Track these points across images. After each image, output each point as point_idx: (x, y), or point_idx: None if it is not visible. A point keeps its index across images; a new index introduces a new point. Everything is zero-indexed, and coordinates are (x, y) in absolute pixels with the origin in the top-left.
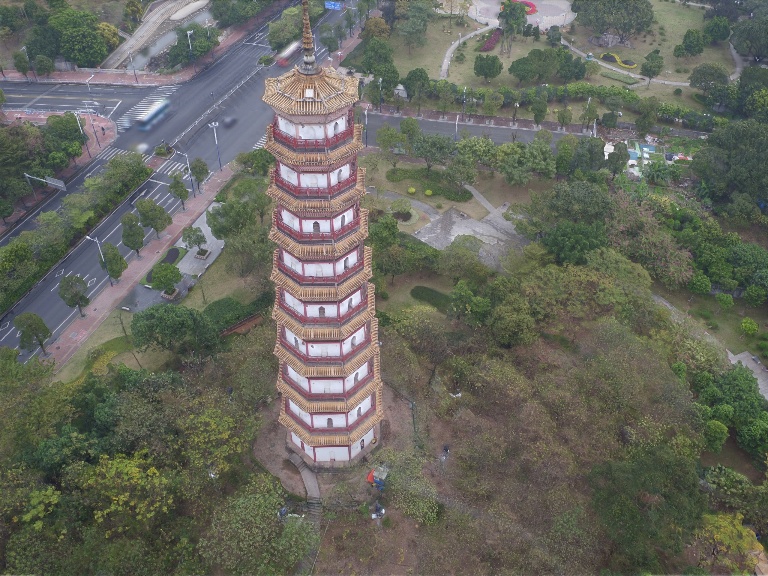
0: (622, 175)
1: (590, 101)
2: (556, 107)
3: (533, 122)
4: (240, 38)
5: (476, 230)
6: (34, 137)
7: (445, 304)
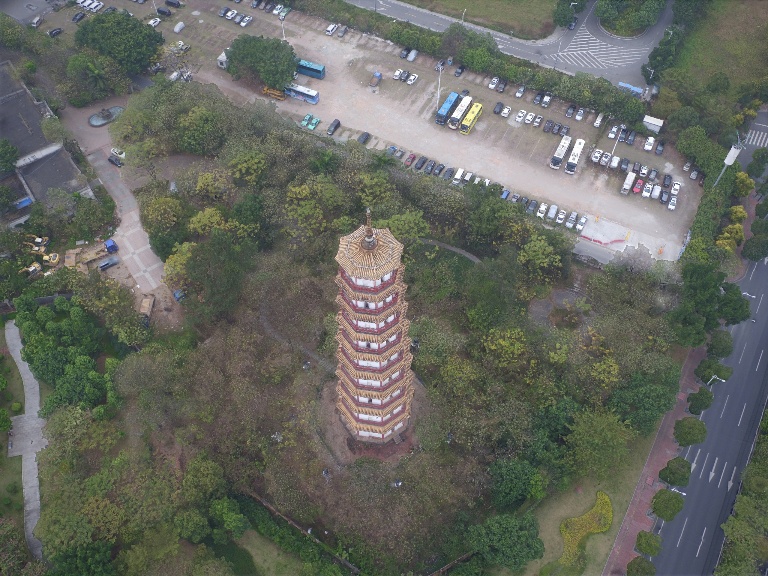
0: None
1: None
2: None
3: None
4: None
5: None
6: None
7: (242, 559)
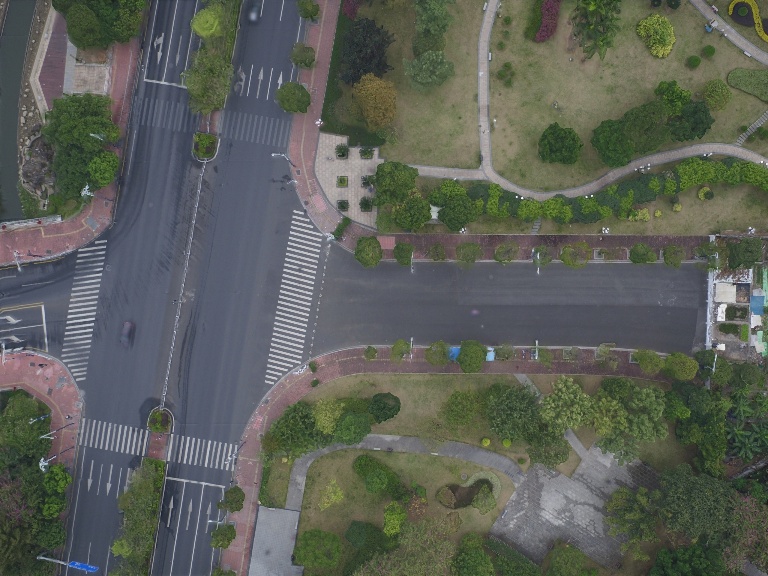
0: (744, 390)
1: (716, 258)
2: (659, 204)
3: (626, 243)
4: (133, 64)
5: (568, 496)
6: (7, 495)
7: None
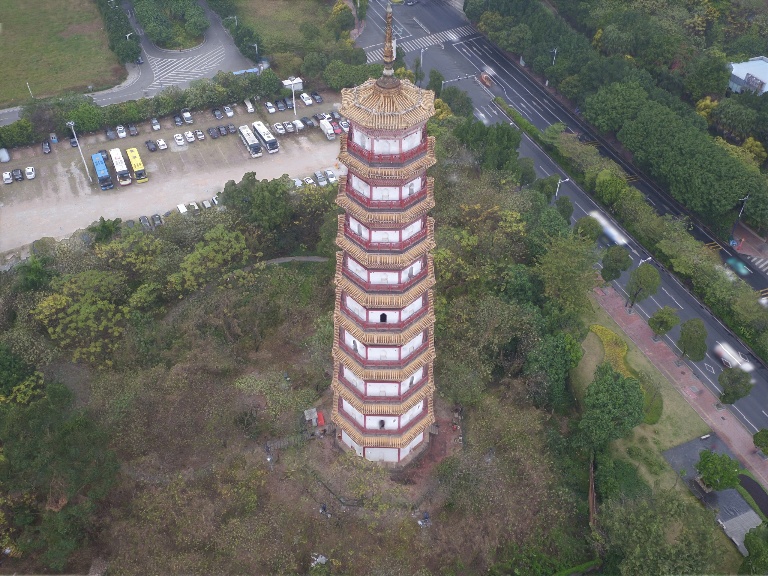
0: None
1: None
2: None
3: None
4: None
5: None
6: None
7: None
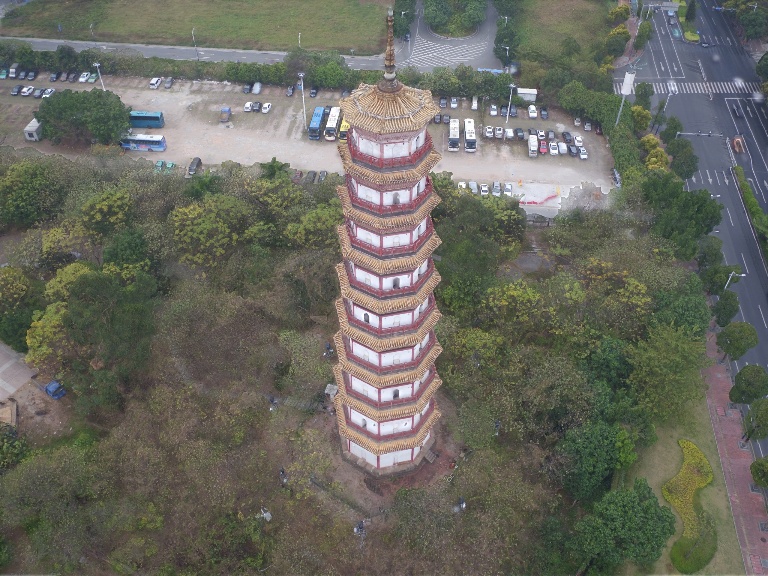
0: None
1: None
2: None
3: None
4: None
5: None
6: None
7: None
